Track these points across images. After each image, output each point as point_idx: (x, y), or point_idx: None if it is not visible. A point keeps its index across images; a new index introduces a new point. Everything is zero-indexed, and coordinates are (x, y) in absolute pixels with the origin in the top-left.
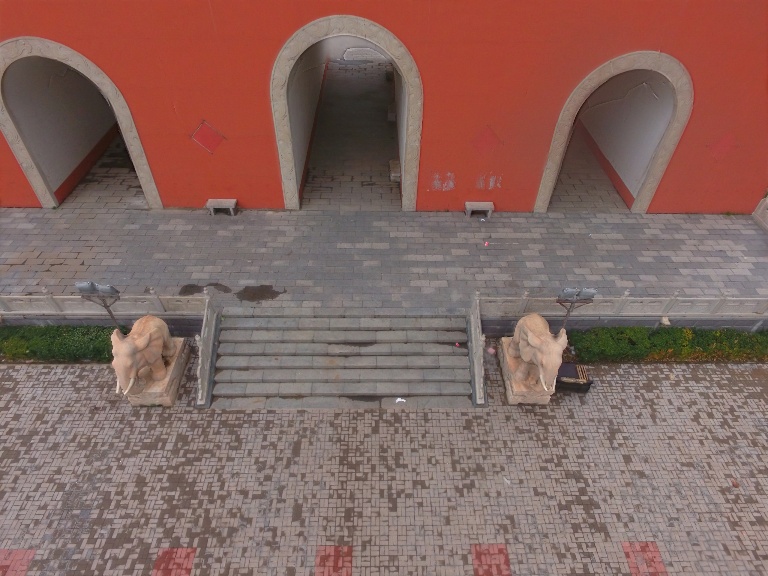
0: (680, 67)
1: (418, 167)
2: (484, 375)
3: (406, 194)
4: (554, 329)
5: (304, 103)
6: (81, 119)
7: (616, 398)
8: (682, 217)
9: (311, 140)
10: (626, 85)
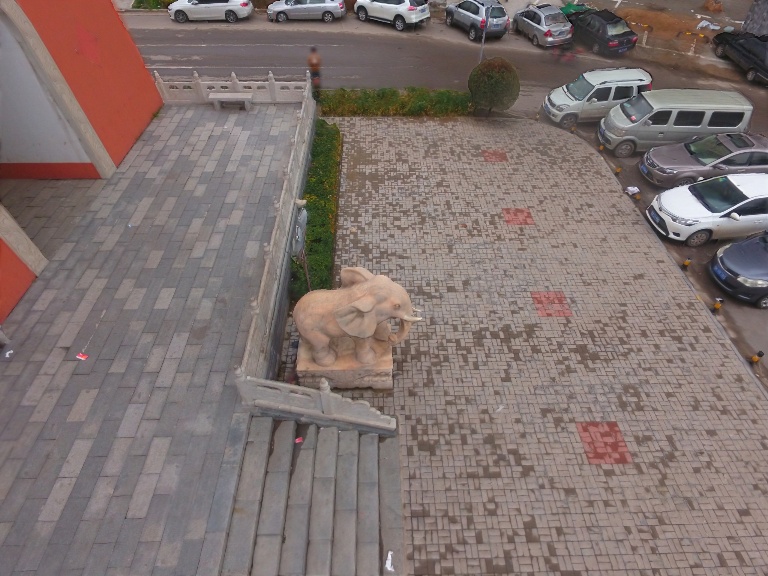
0: None
1: None
2: None
3: None
4: (283, 308)
5: None
6: None
7: None
8: (141, 145)
9: None
10: None
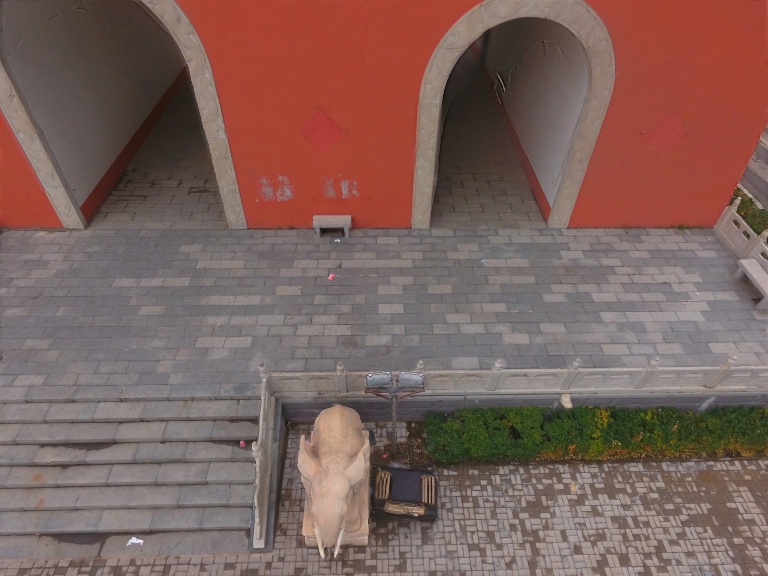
0: (588, 13)
1: (233, 168)
2: (278, 493)
3: (227, 206)
4: (402, 411)
5: (110, 82)
6: None
7: (480, 530)
8: (617, 233)
9: (139, 132)
10: (513, 44)
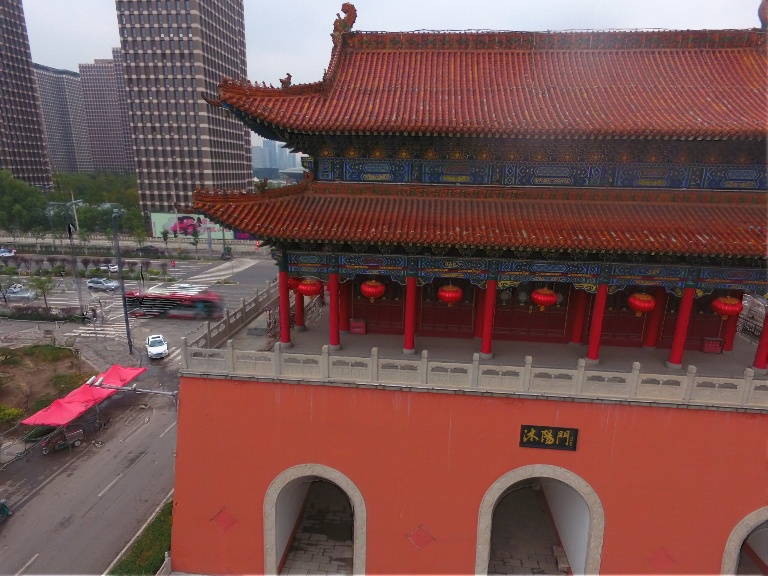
0: None
1: (598, 575)
2: None
3: None
4: None
5: None
6: (299, 491)
7: None
8: None
9: None
10: None
